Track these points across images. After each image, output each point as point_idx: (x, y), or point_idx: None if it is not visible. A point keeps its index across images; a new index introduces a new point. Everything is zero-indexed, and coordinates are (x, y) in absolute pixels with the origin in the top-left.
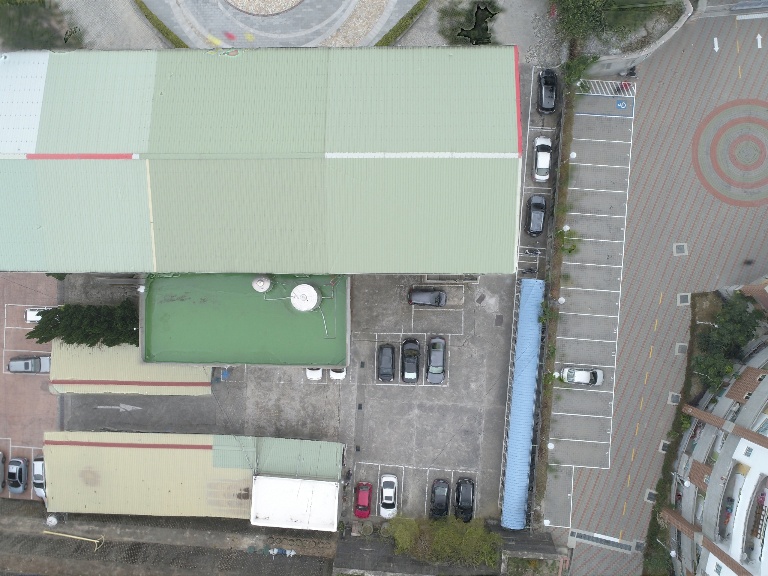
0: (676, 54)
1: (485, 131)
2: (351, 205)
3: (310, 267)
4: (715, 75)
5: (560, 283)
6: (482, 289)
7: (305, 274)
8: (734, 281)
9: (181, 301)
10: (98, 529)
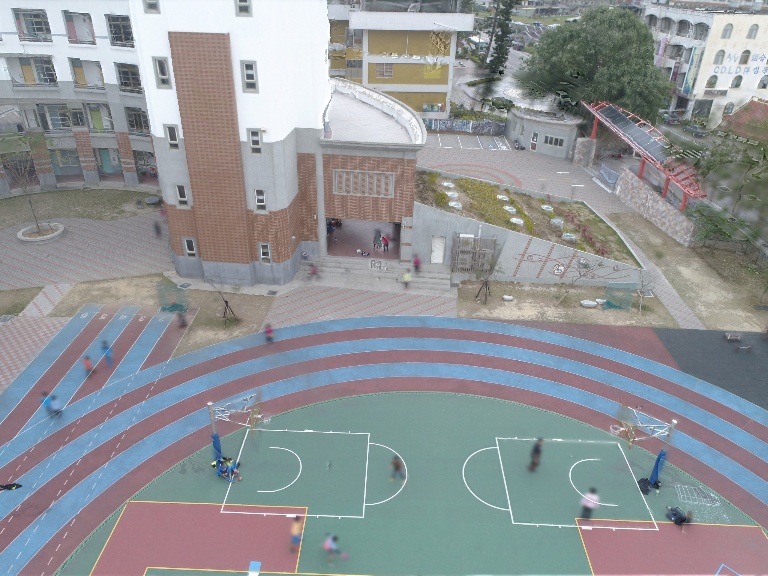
0: (545, 161)
1: None
2: None
3: None
4: (535, 172)
5: None
6: None
7: None
8: None
9: None
10: None
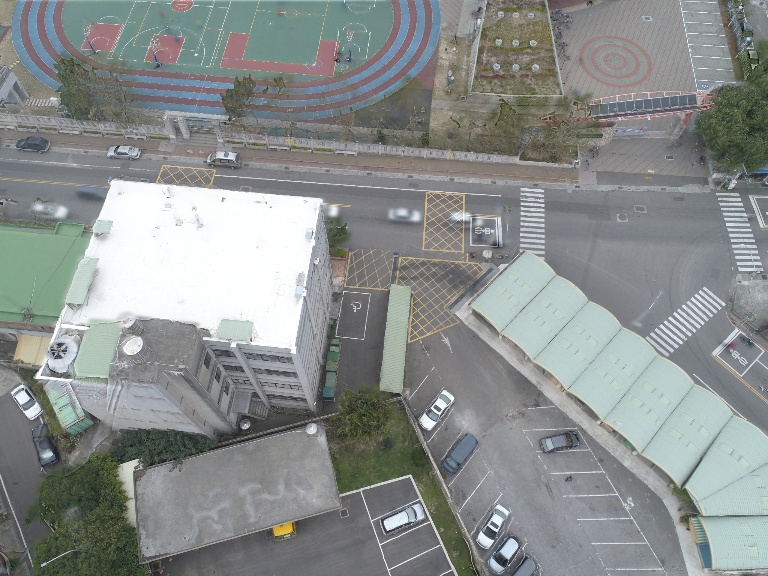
0: None
1: None
2: None
3: None
4: None
5: (719, 5)
6: (763, 8)
7: None
8: (612, 4)
9: None
10: None
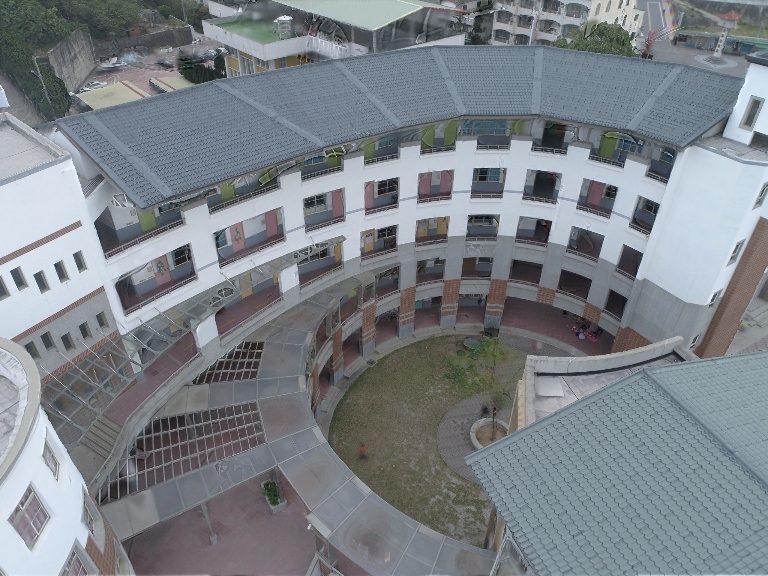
0: None
1: (420, 4)
2: (342, 0)
3: (301, 8)
4: None
5: None
6: None
7: (296, 8)
8: None
9: (244, 26)
10: (74, 113)
